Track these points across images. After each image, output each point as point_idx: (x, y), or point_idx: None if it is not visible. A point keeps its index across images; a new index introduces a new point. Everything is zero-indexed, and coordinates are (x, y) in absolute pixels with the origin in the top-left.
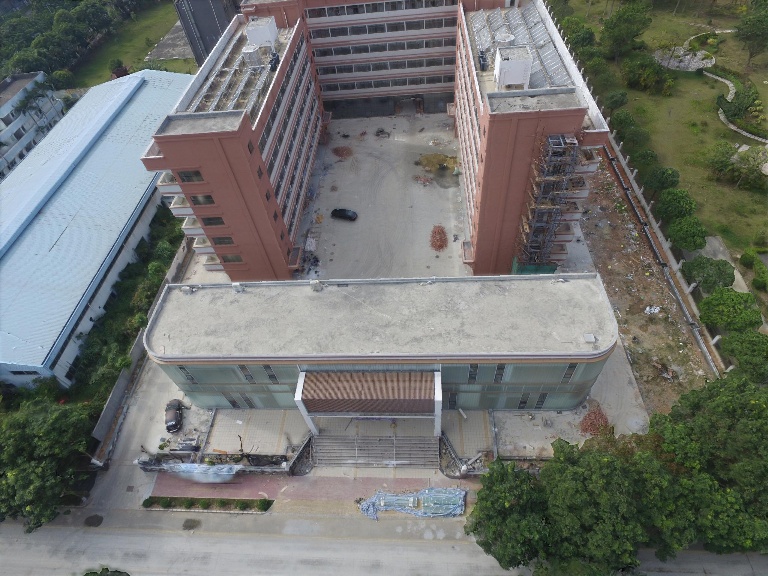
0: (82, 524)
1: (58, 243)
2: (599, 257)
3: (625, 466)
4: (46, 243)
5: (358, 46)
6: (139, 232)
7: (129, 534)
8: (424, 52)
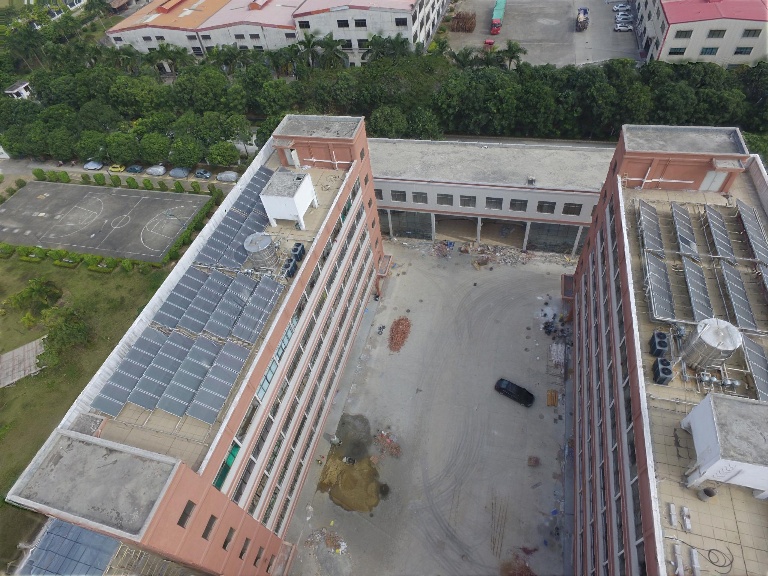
0: None
1: None
2: None
3: (368, 125)
4: None
5: None
6: None
7: None
8: None
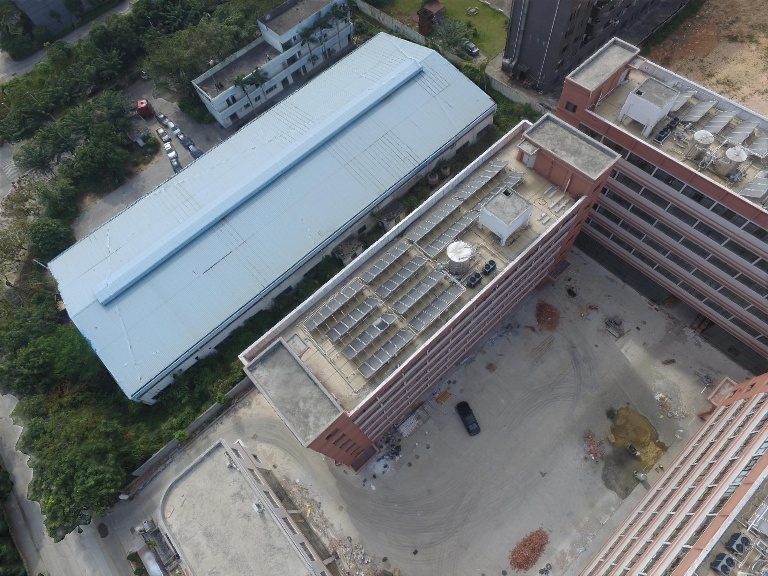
0: (97, 525)
1: (214, 268)
2: None
3: None
4: (206, 262)
5: (669, 226)
6: (288, 282)
7: (110, 567)
8: (759, 299)
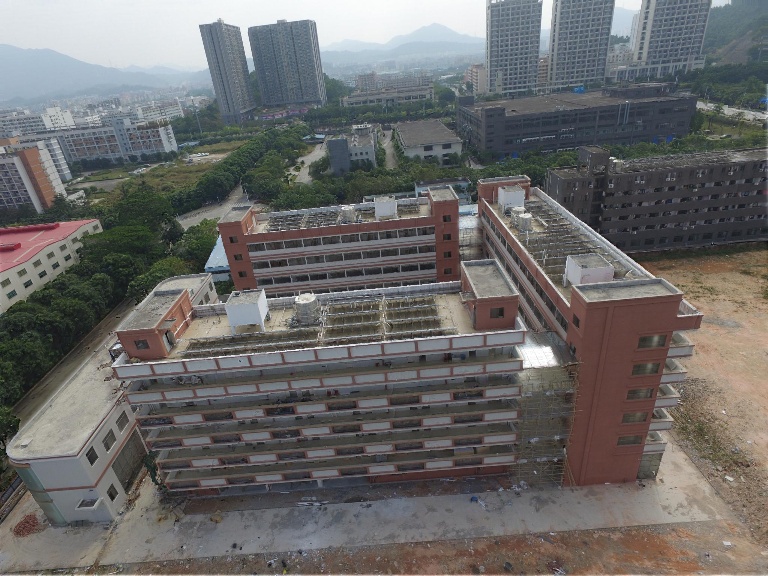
0: None
1: None
2: (200, 567)
3: None
4: None
5: None
6: None
7: None
8: None
